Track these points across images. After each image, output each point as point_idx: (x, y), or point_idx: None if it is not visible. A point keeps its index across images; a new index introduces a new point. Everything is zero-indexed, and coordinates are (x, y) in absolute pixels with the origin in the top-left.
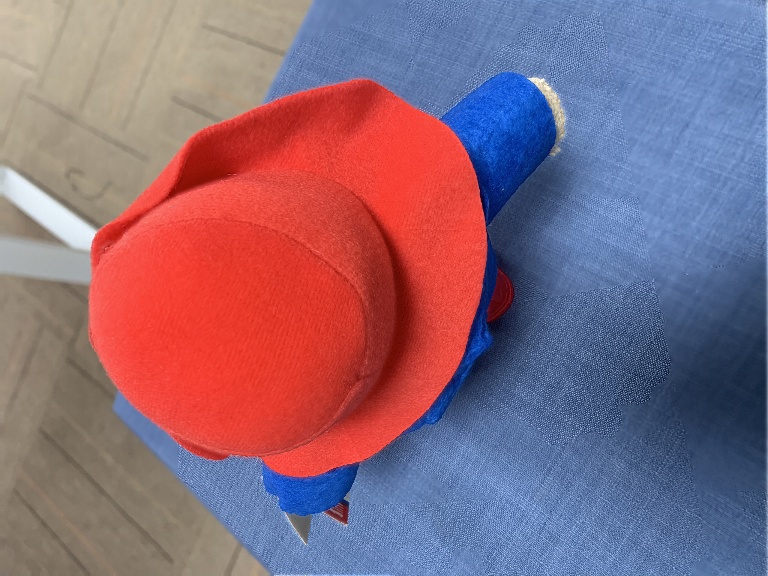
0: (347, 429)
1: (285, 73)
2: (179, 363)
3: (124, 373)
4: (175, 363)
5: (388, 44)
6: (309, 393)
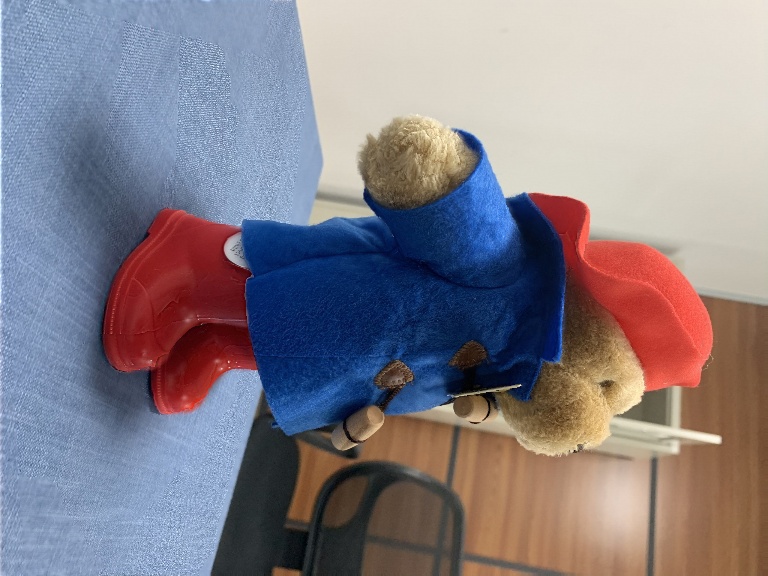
0: None
1: None
2: None
3: None
4: None
5: None
6: None
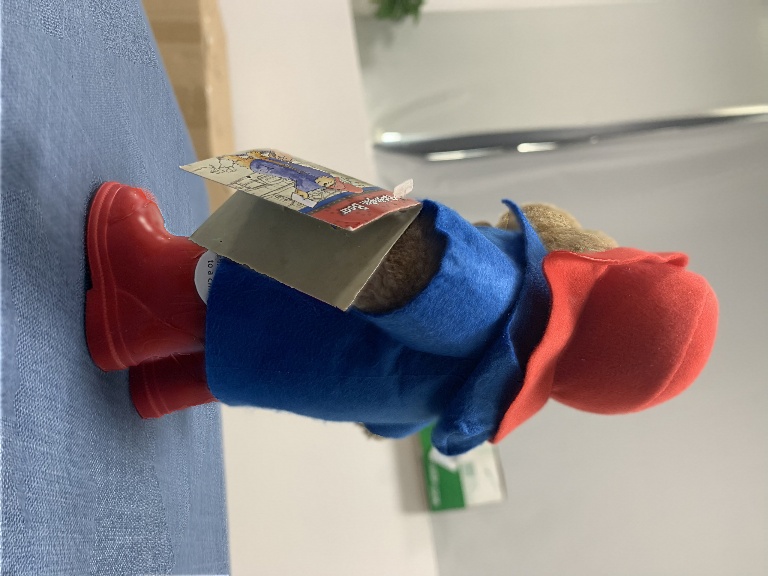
0: None
1: None
2: None
3: None
4: None
5: None
6: None
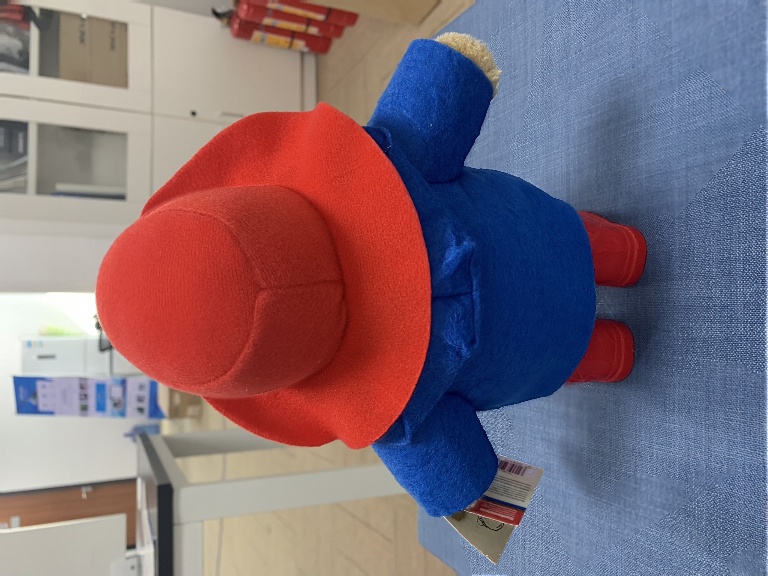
0: (371, 377)
1: None
2: (124, 314)
3: (118, 343)
4: (123, 315)
5: None
6: (207, 302)
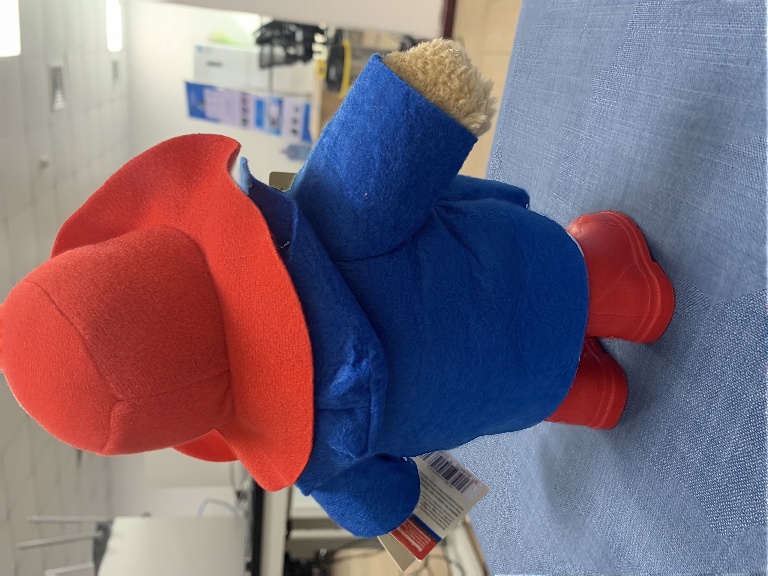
0: (263, 450)
1: (508, 83)
2: None
3: None
4: None
5: (569, 14)
6: (63, 408)
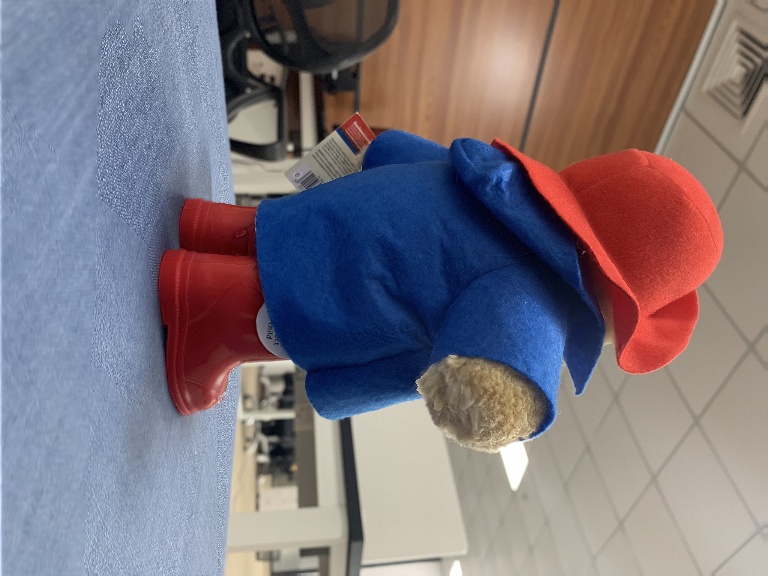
0: None
1: None
2: None
3: None
4: None
5: None
6: None
